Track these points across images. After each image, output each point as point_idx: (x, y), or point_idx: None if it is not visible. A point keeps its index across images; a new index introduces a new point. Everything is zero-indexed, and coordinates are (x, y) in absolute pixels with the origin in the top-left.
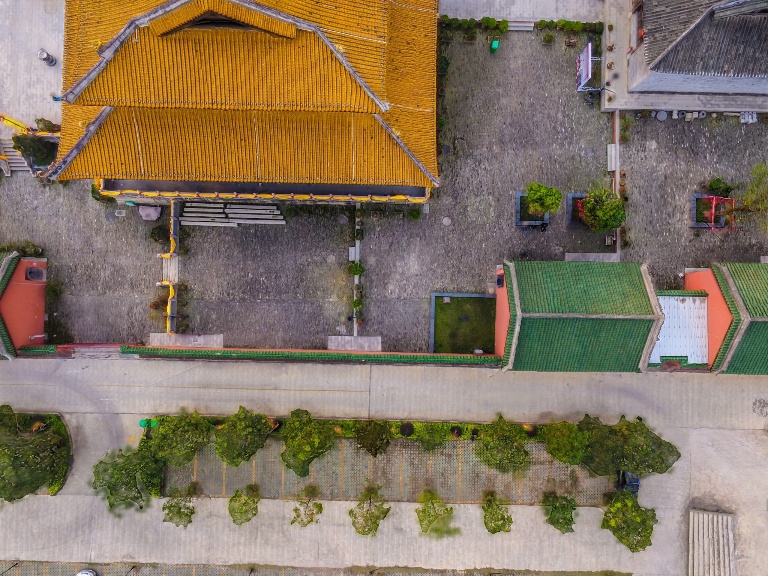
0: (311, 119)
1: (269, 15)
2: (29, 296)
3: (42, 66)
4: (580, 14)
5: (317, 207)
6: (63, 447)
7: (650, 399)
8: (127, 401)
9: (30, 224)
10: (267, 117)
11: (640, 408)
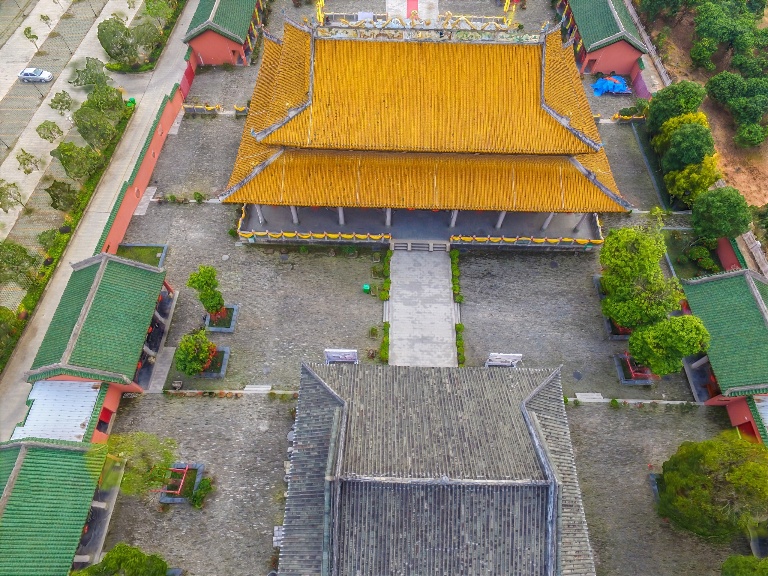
0: None
1: None
2: (223, 53)
3: None
4: (397, 359)
5: None
6: (131, 68)
7: (7, 426)
8: (151, 96)
9: None
10: None
11: (2, 416)
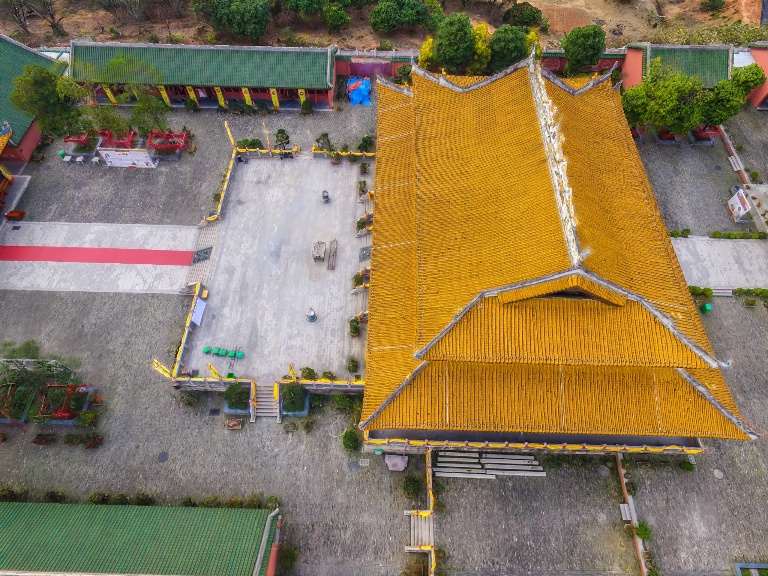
0: (615, 372)
1: (612, 289)
2: (270, 565)
3: (304, 322)
4: None
5: (574, 457)
6: None
7: None
8: None
9: (268, 474)
10: (573, 370)
11: None
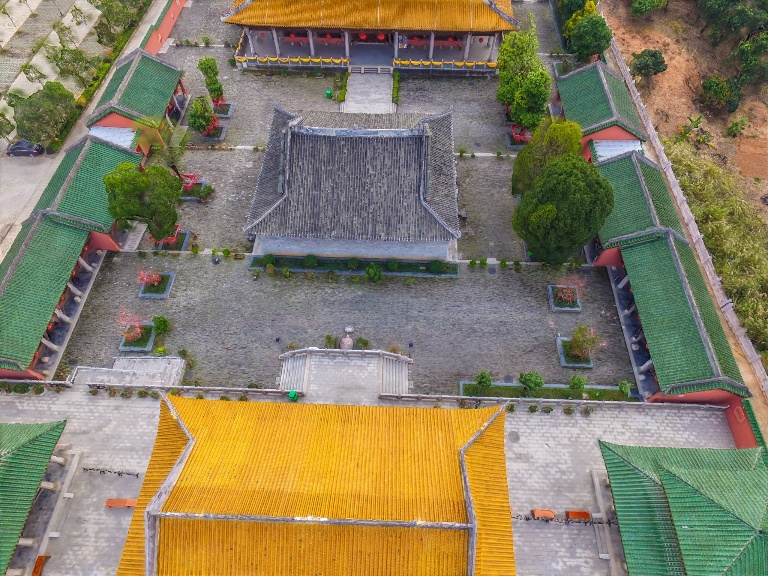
0: None
1: None
2: None
3: None
4: None
5: None
6: None
7: None
8: None
9: None
10: None
11: None
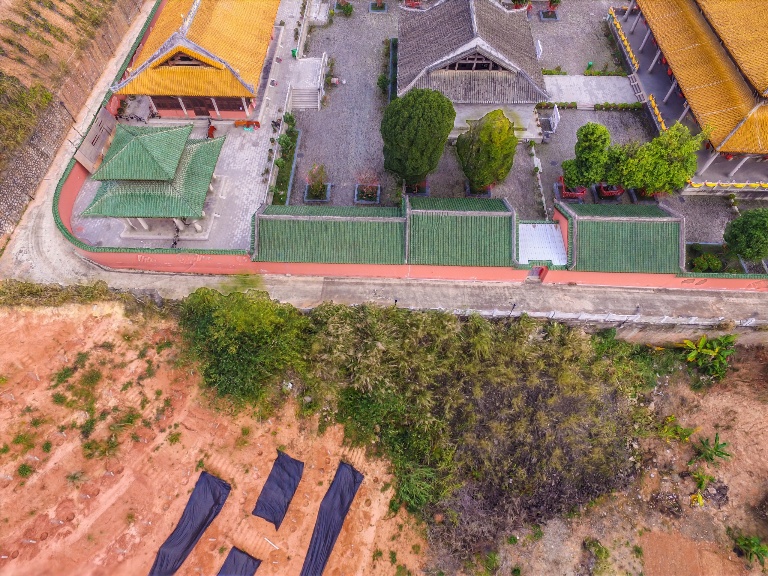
0: None
1: None
2: None
3: None
4: None
5: None
6: None
7: None
8: None
9: None
10: None
11: None
